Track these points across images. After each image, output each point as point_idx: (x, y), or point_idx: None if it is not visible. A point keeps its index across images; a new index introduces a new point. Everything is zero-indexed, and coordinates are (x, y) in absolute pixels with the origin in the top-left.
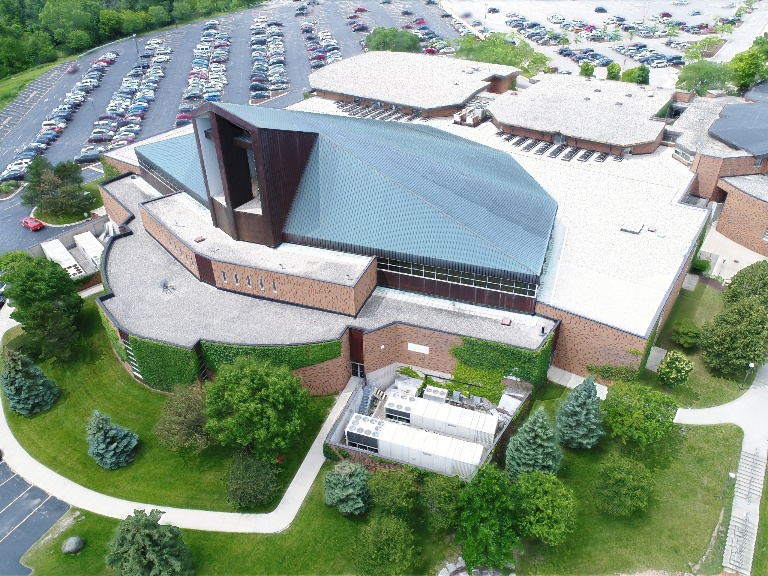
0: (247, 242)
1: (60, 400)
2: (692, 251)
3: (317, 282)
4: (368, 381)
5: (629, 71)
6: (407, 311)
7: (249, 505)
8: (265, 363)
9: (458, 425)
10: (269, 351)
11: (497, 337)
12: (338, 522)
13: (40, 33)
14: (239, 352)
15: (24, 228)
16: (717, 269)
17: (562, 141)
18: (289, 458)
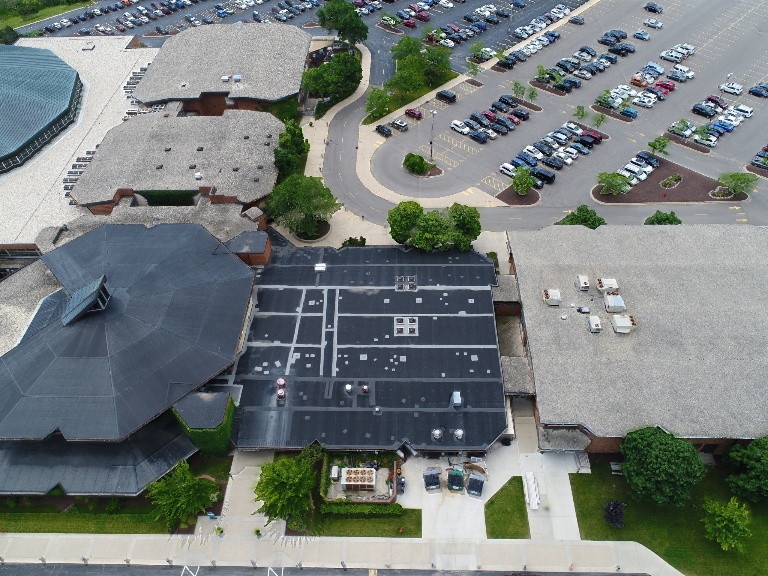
0: None
1: None
2: None
3: None
4: None
5: (408, 156)
6: None
7: None
8: None
9: None
10: None
11: None
12: None
13: None
14: None
15: None
16: None
17: None
18: None
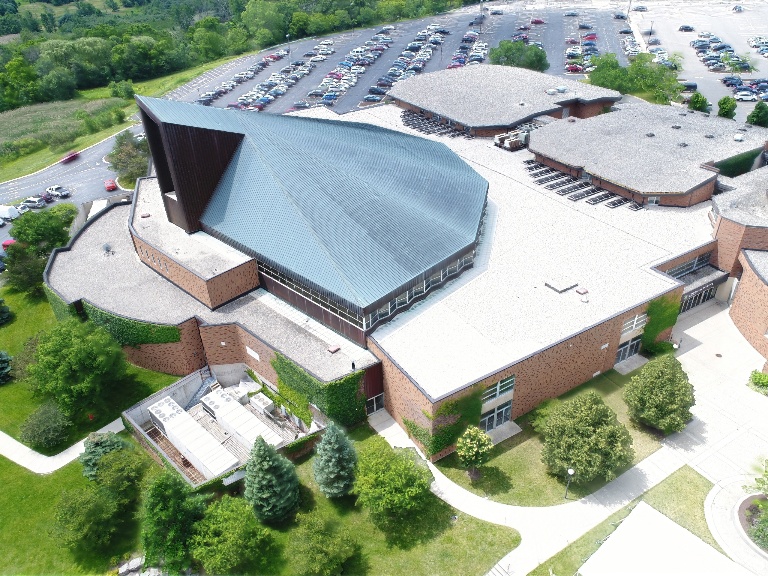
0: (175, 225)
1: (7, 324)
2: (611, 326)
3: (186, 270)
4: (212, 373)
5: None
6: (261, 316)
7: (31, 443)
8: (96, 329)
9: (242, 435)
10: (121, 321)
11: (310, 361)
12: (88, 483)
13: (240, 30)
14: (103, 316)
15: (104, 188)
16: (682, 358)
17: (590, 178)
18: (100, 418)
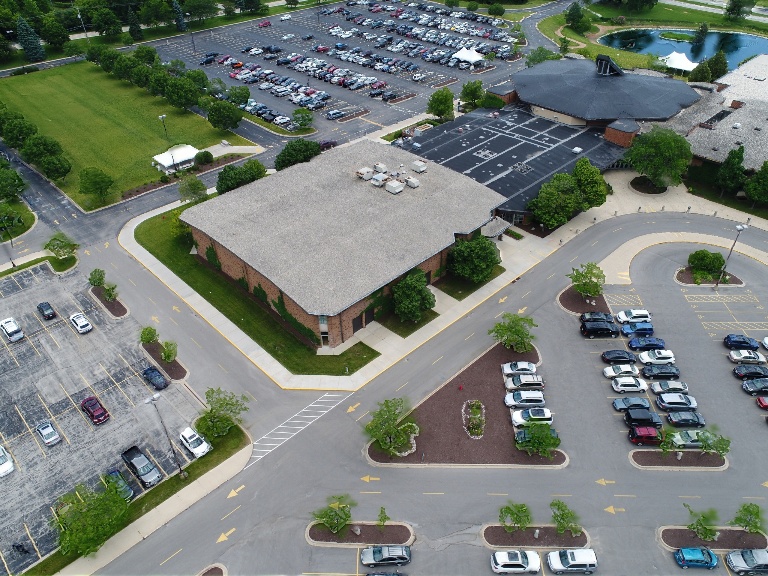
0: None
1: None
2: None
3: None
4: None
5: None
6: None
7: None
8: None
9: None
10: None
11: None
12: None
13: None
14: None
15: None
16: None
17: None
18: None
